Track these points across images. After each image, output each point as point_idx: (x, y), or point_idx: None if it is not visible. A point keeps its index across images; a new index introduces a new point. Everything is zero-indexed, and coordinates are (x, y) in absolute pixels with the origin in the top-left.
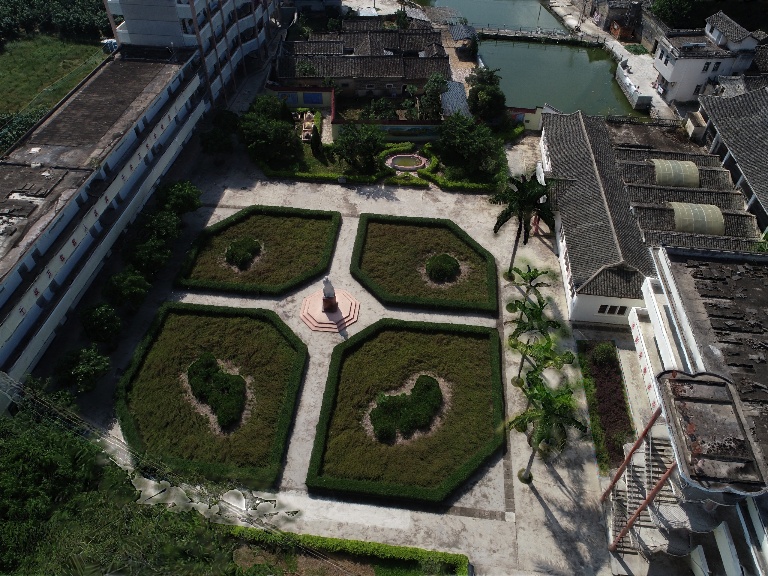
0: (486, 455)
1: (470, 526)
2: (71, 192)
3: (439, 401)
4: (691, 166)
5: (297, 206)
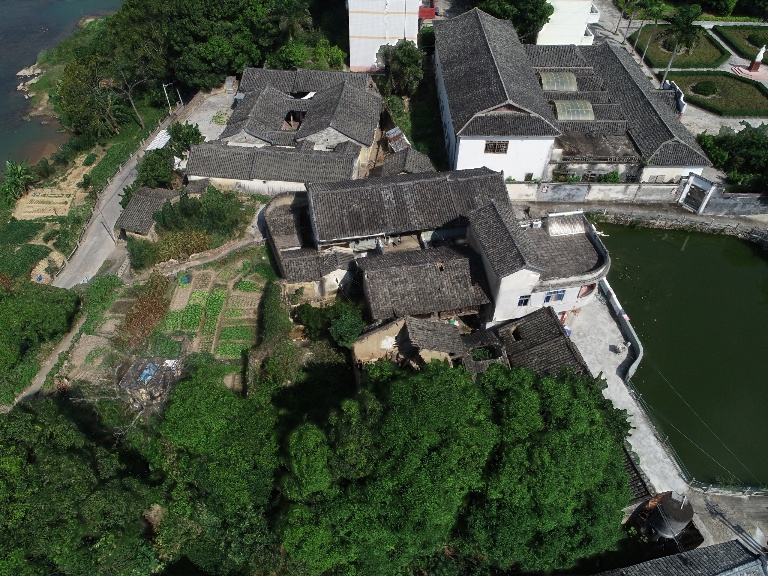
0: (636, 32)
1: None
2: None
3: None
4: (560, 103)
5: None
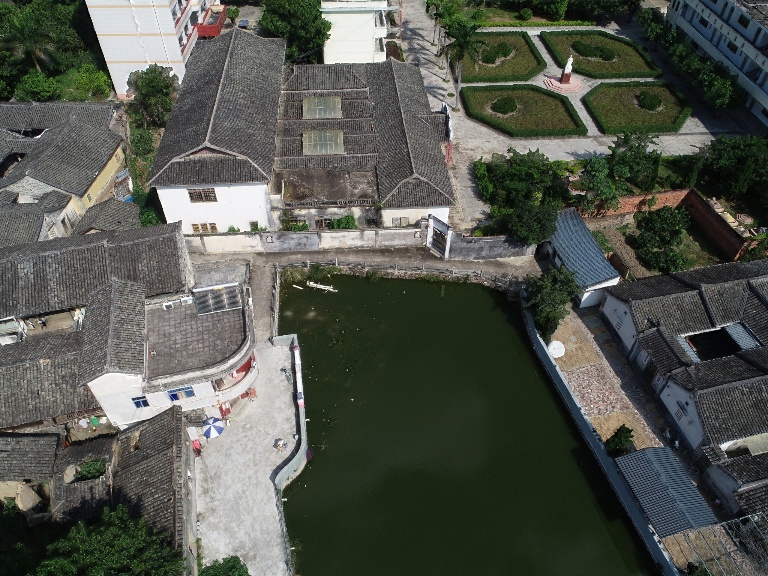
0: (454, 42)
1: None
2: (744, 10)
3: None
4: (308, 135)
5: None
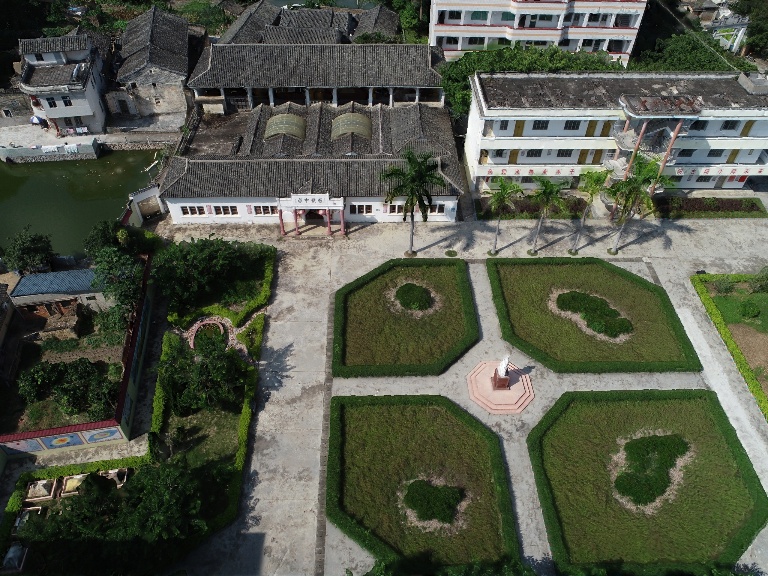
0: (614, 265)
1: (665, 278)
2: None
3: None
4: (286, 116)
5: (312, 459)
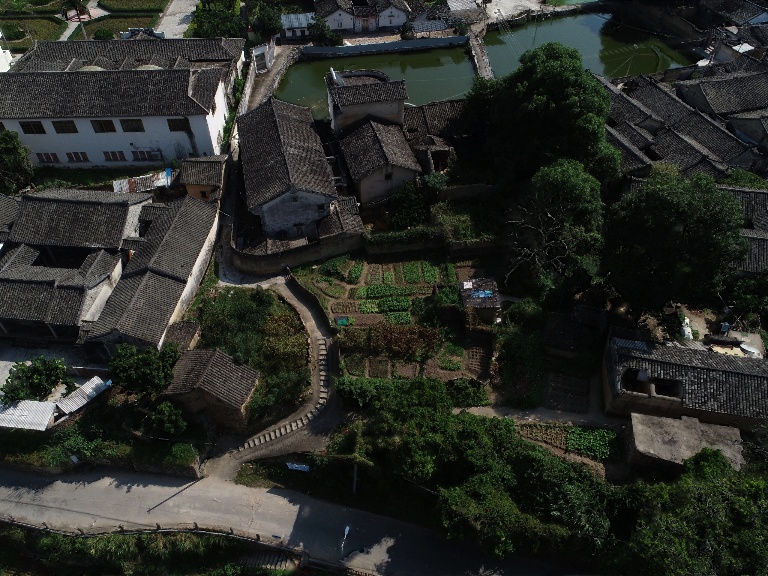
0: None
1: None
2: None
3: (8, 37)
4: None
5: (176, 2)
